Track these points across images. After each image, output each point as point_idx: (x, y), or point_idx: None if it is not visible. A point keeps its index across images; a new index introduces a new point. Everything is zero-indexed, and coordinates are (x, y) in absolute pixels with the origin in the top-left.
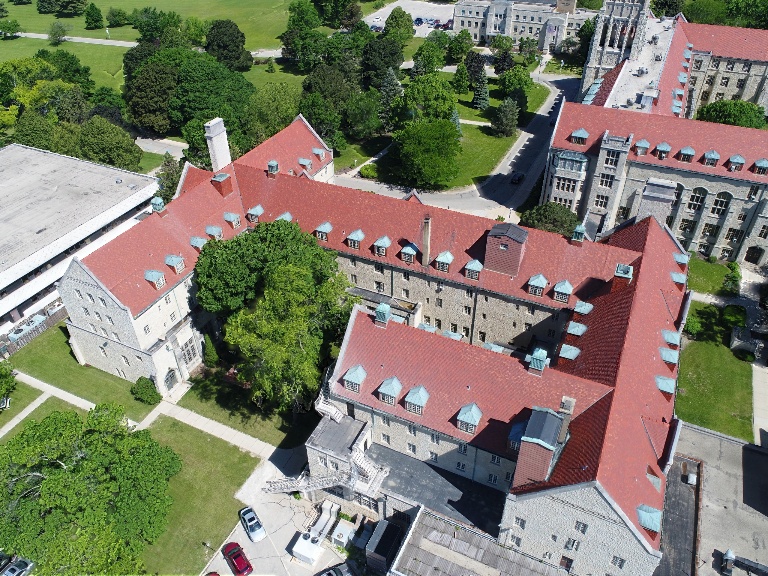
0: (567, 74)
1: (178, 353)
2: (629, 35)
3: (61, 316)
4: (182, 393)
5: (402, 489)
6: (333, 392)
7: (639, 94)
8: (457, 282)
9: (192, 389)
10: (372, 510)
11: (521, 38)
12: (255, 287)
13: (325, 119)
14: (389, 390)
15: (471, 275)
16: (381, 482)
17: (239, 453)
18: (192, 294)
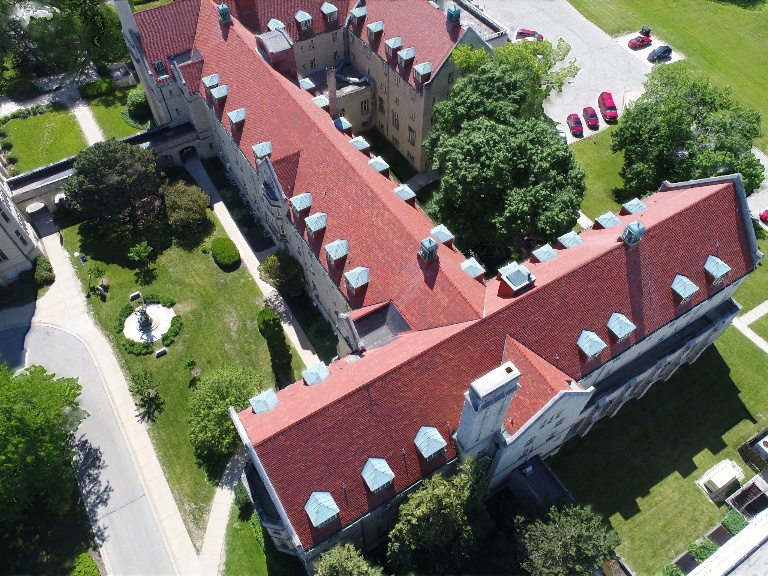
0: None
1: None
2: None
3: None
4: None
5: None
6: None
7: None
8: None
9: None
10: None
11: None
12: None
13: None
14: None
15: None
16: None
17: None
18: None
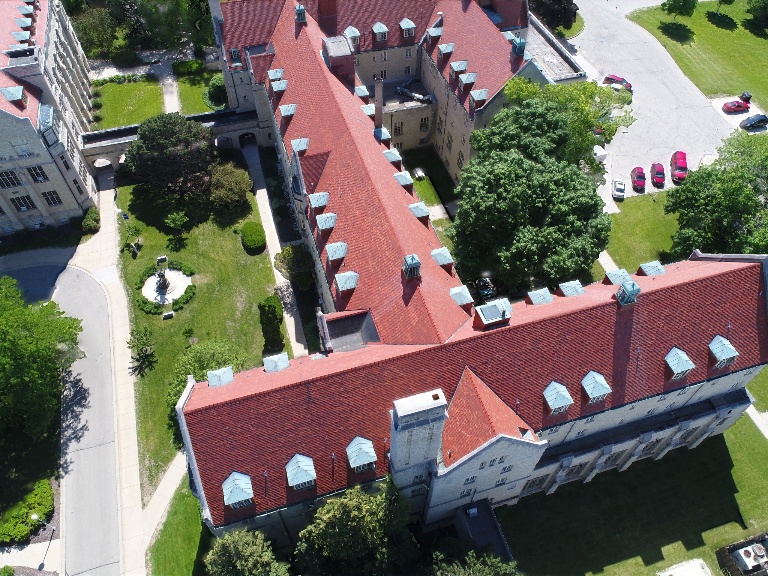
0: None
1: None
2: None
3: None
4: None
5: None
6: None
7: None
8: None
9: None
10: None
11: None
12: None
13: None
14: (537, 64)
15: None
16: None
17: None
18: None
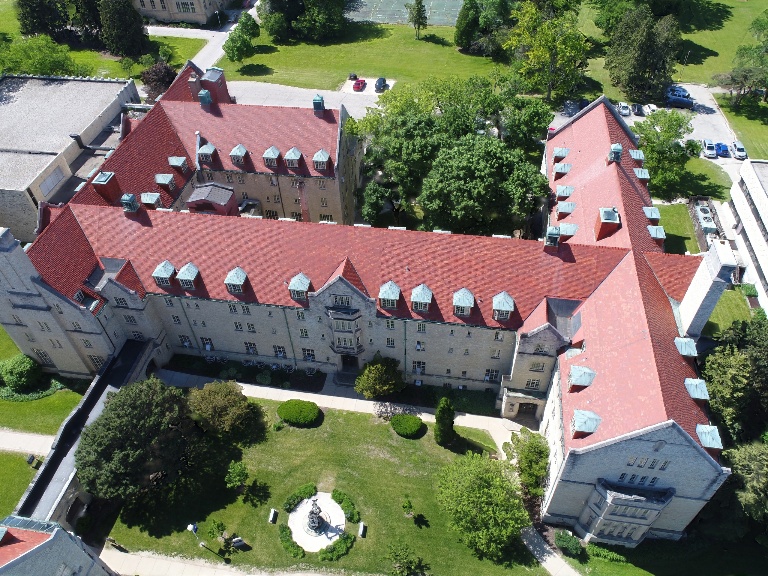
0: None
1: None
2: None
3: None
4: None
5: None
6: None
7: None
8: None
9: None
10: None
11: None
12: None
13: None
14: None
15: None
16: None
17: None
18: None
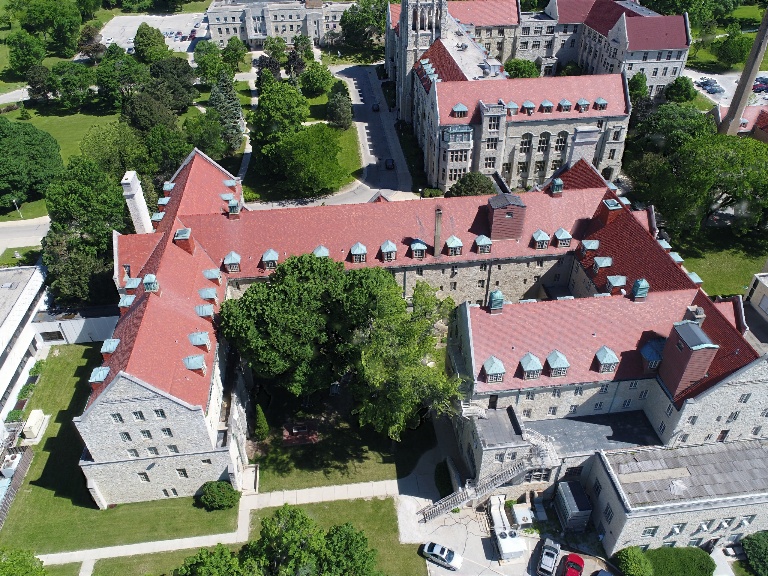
0: (345, 64)
1: (239, 438)
2: (436, 17)
3: (23, 469)
4: (253, 480)
5: (568, 448)
6: (477, 392)
7: (480, 65)
8: (472, 261)
9: (262, 470)
10: (541, 481)
11: (295, 36)
12: (326, 329)
13: (183, 151)
14: (534, 366)
15: (483, 250)
16: (553, 450)
17: (368, 503)
18: (220, 369)
